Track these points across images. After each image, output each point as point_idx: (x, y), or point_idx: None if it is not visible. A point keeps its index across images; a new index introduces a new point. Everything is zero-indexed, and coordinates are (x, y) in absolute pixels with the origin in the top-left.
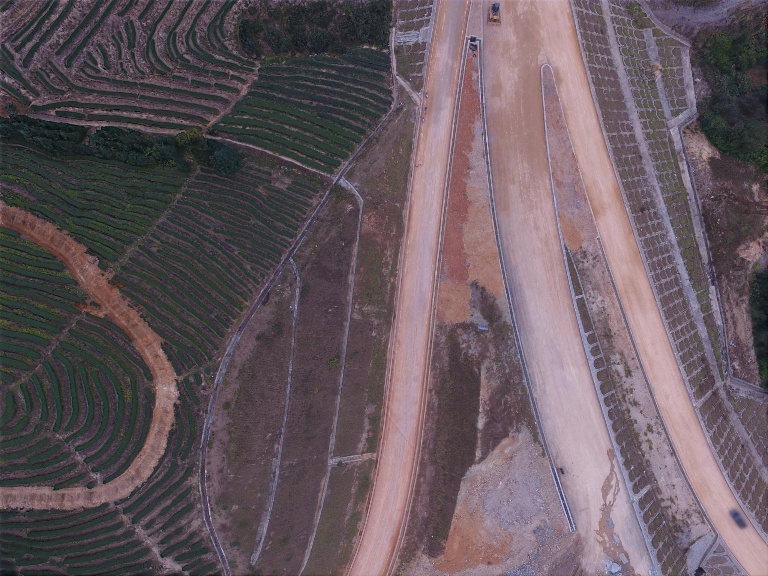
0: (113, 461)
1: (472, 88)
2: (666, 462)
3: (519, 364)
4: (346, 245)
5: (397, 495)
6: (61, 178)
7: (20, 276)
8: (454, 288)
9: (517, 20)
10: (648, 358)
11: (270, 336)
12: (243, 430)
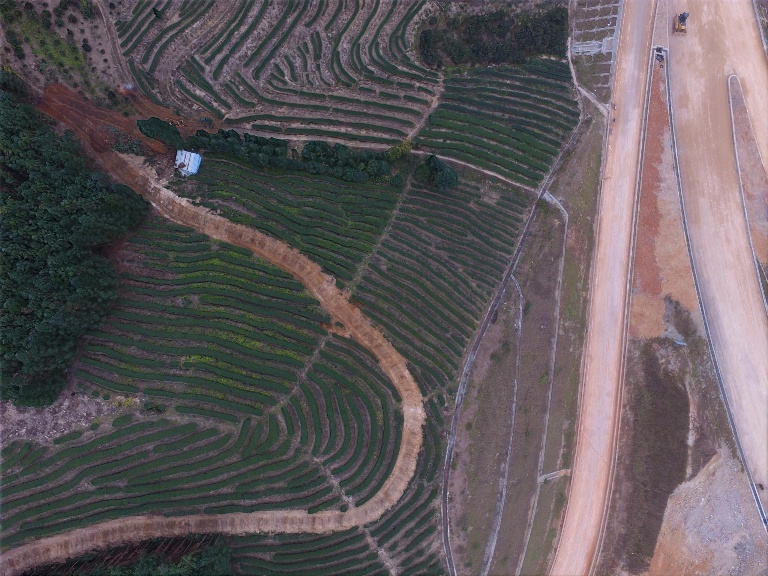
0: (367, 484)
1: (660, 99)
2: None
3: (715, 379)
4: (554, 260)
5: (591, 511)
6: (276, 194)
7: (263, 296)
8: (647, 302)
9: (702, 30)
10: None
11: (500, 355)
12: (479, 451)
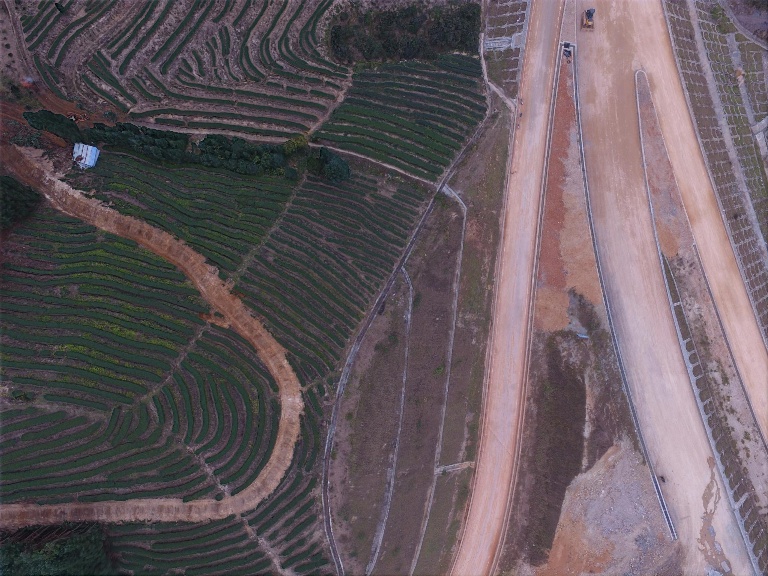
0: (241, 473)
1: (567, 94)
2: (763, 470)
3: (618, 372)
4: (451, 253)
5: (495, 503)
6: (170, 187)
7: (143, 287)
8: (552, 296)
9: (610, 26)
10: (744, 365)
11: (386, 346)
12: (363, 441)
